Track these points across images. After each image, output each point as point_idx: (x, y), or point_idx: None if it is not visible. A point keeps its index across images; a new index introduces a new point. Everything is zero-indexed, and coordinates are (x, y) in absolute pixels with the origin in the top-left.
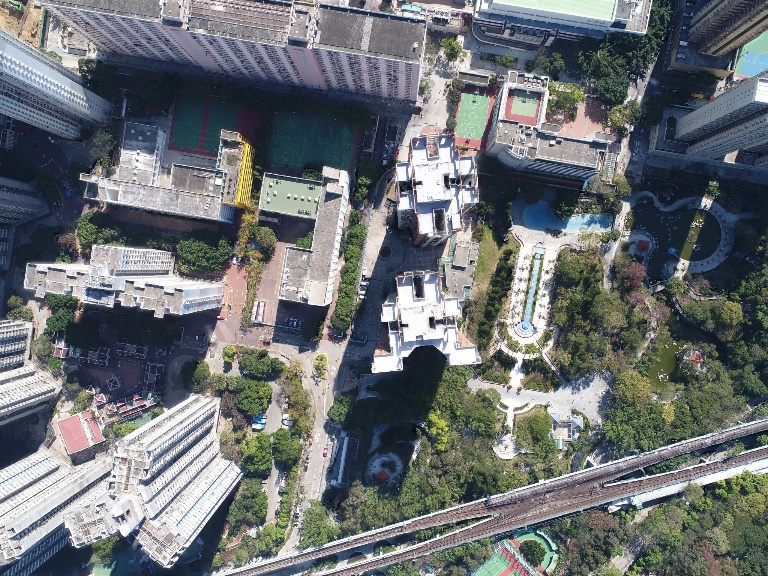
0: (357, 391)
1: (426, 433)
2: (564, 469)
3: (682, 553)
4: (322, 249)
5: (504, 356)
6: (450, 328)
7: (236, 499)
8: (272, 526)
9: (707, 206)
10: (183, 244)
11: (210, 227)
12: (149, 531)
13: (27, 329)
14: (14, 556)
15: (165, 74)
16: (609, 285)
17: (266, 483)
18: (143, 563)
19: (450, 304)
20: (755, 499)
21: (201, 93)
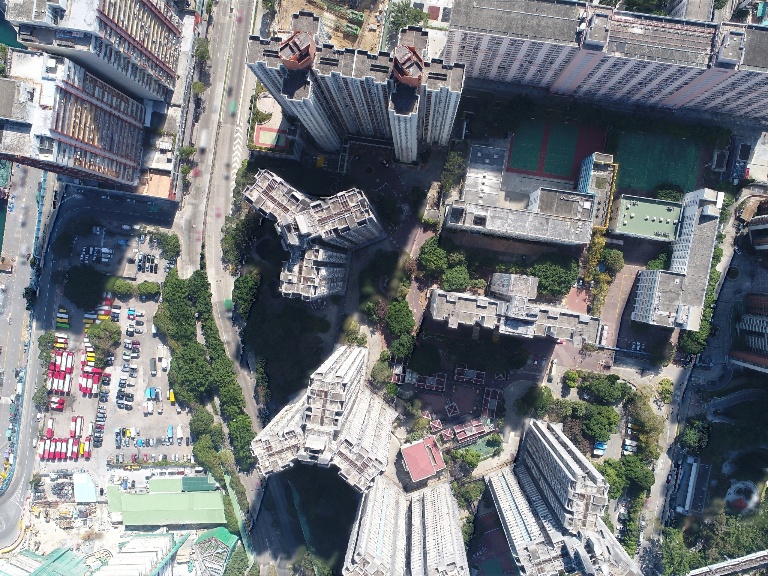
0: (704, 416)
1: None
2: None
3: None
4: (695, 273)
5: None
6: None
7: None
8: None
9: None
10: (537, 268)
11: (549, 250)
12: None
13: (364, 355)
14: None
15: (517, 96)
16: None
17: None
18: None
19: None
20: None
21: (554, 115)
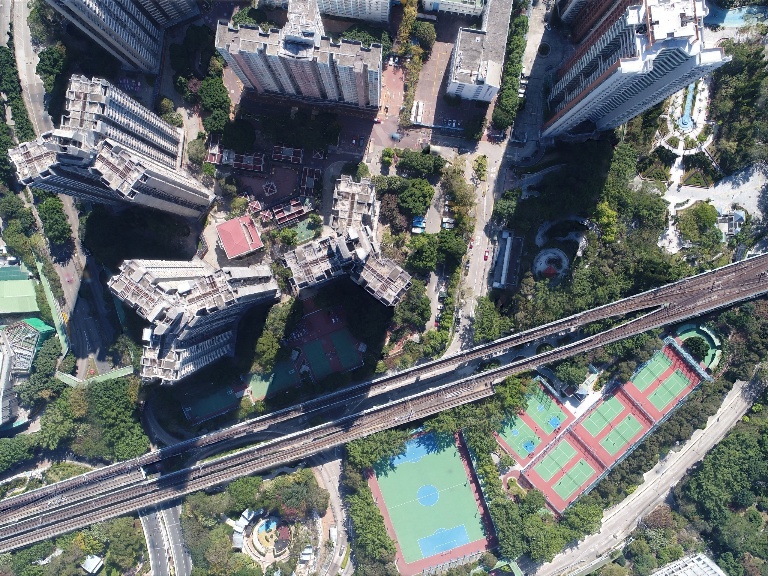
0: None
1: None
2: (725, 264)
3: None
4: (496, 30)
5: (666, 150)
6: None
7: (400, 302)
8: (434, 331)
9: None
10: (346, 36)
11: None
12: (373, 268)
13: (179, 134)
14: (233, 299)
15: None
16: None
17: None
18: (304, 373)
19: None
20: None
21: None
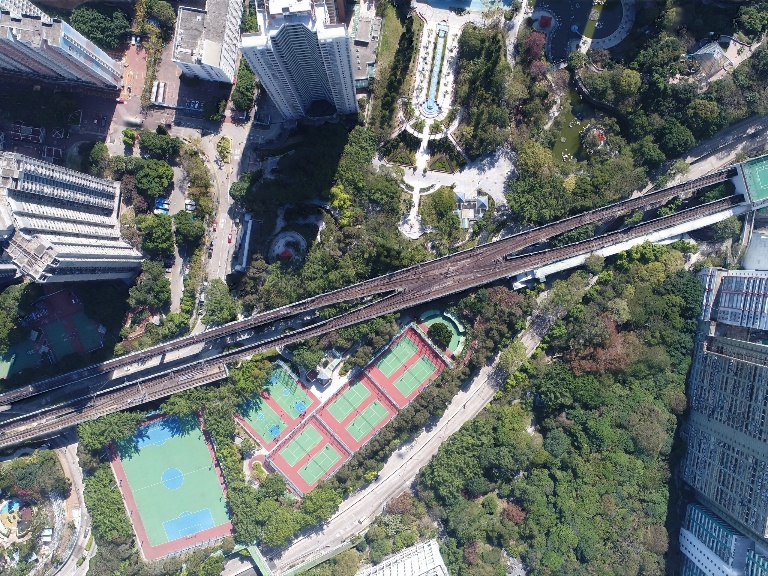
0: (261, 173)
1: (331, 214)
2: None
3: (584, 323)
4: (217, 10)
5: (408, 135)
6: (319, 6)
7: (137, 283)
8: (176, 314)
9: None
10: (76, 13)
11: None
12: (19, 243)
13: None
14: None
15: None
16: (513, 63)
17: (170, 272)
18: (42, 353)
19: None
20: (655, 267)
21: None
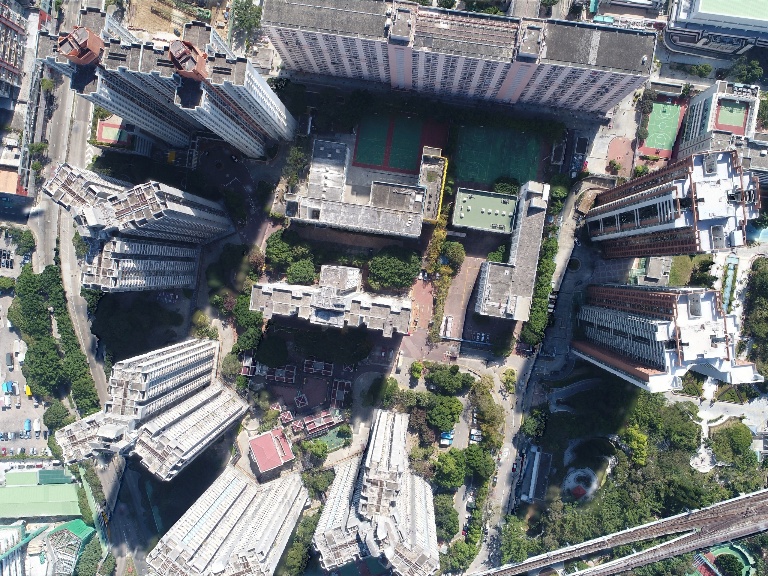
0: (547, 405)
1: (619, 447)
2: (760, 482)
3: None
4: (525, 264)
5: None
6: None
7: None
8: (462, 542)
9: None
10: (377, 261)
11: (395, 243)
12: (401, 553)
13: (214, 348)
14: None
15: (356, 91)
16: None
17: (453, 499)
18: None
19: (728, 322)
20: None
21: (392, 109)
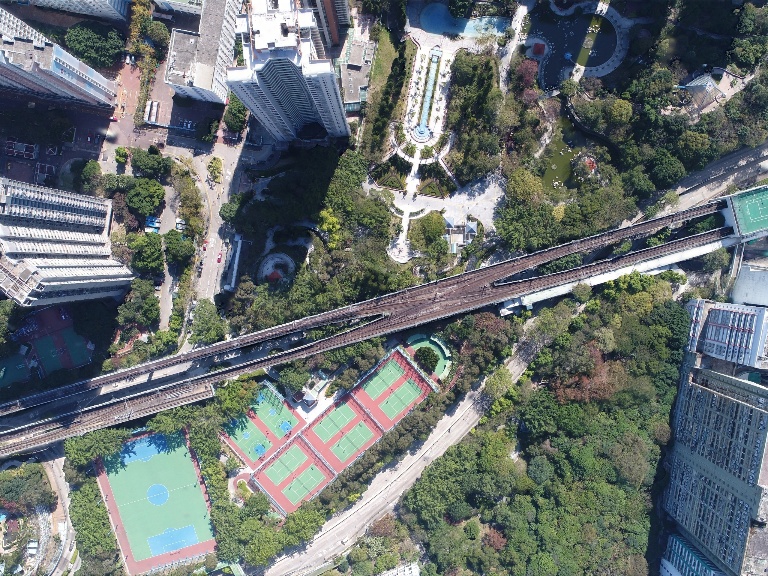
0: (252, 194)
1: (320, 237)
2: None
3: (570, 352)
4: (210, 33)
5: (399, 159)
6: (305, 41)
7: (127, 301)
8: (164, 332)
9: (603, 11)
10: (71, 33)
11: None
12: (5, 268)
13: None
14: None
15: None
16: (505, 89)
17: (160, 290)
18: (32, 368)
19: (304, 15)
20: (642, 298)
21: None
